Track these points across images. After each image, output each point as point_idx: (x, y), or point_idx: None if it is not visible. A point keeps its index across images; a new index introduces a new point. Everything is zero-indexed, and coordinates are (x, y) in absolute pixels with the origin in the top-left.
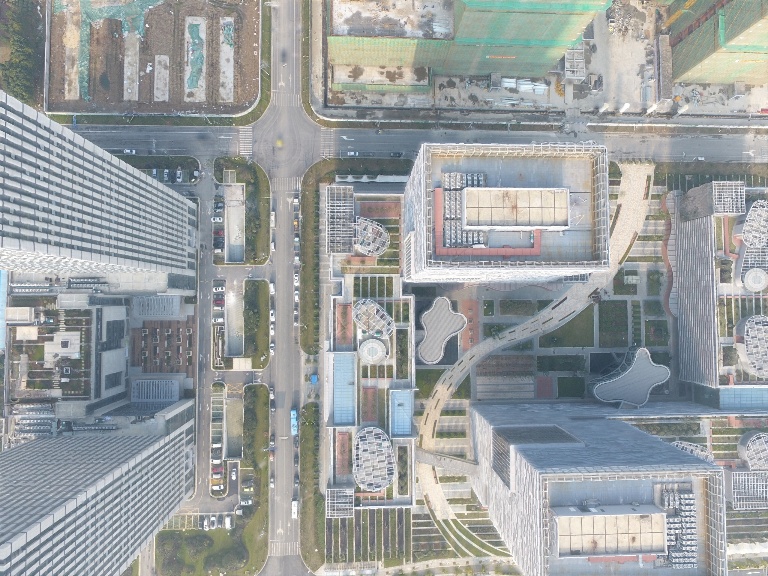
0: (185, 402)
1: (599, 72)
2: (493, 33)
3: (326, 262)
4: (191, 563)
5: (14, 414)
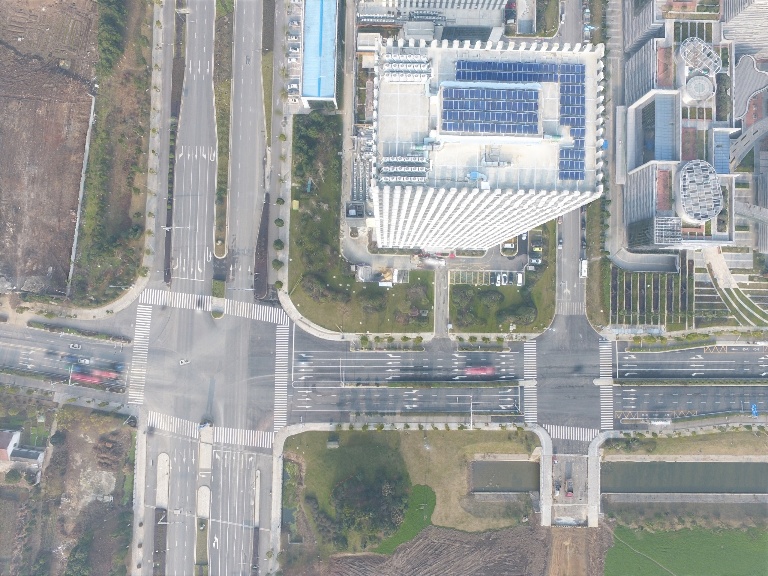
0: None
1: None
2: None
3: (613, 36)
4: (483, 316)
5: (361, 136)
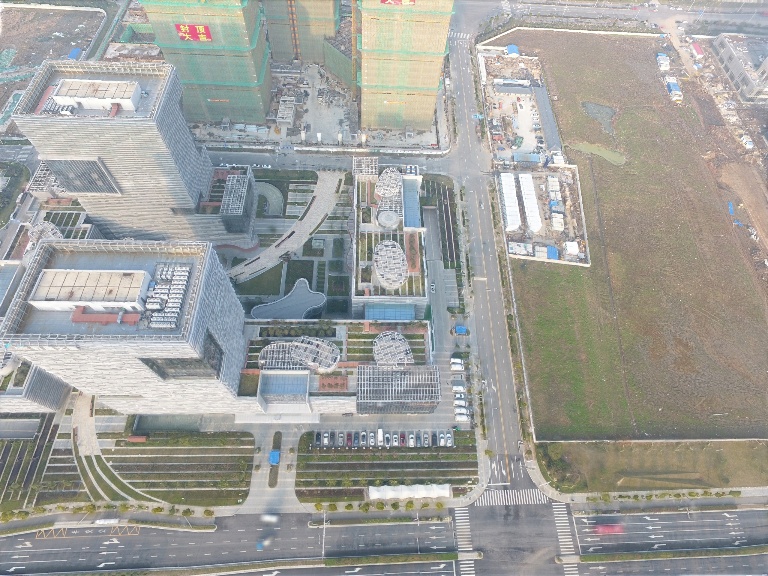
0: None
1: (309, 122)
2: (196, 75)
3: None
4: None
5: None
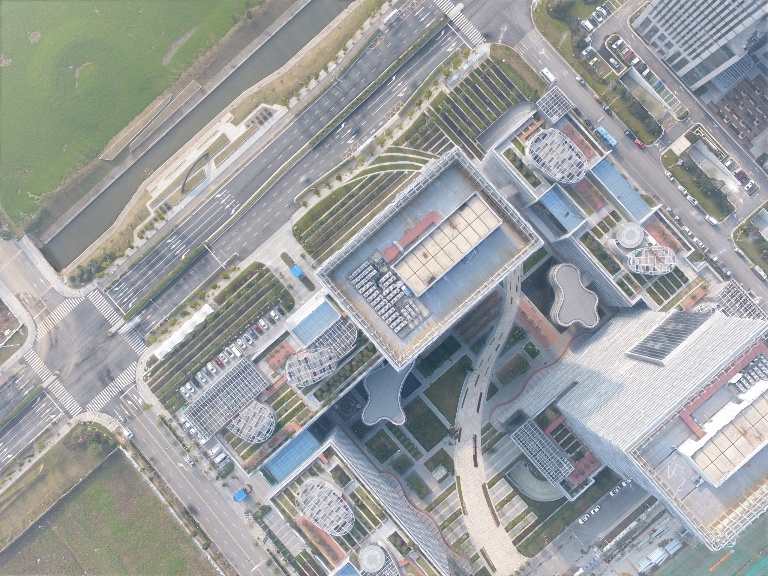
0: None
1: None
2: None
3: None
4: None
5: None
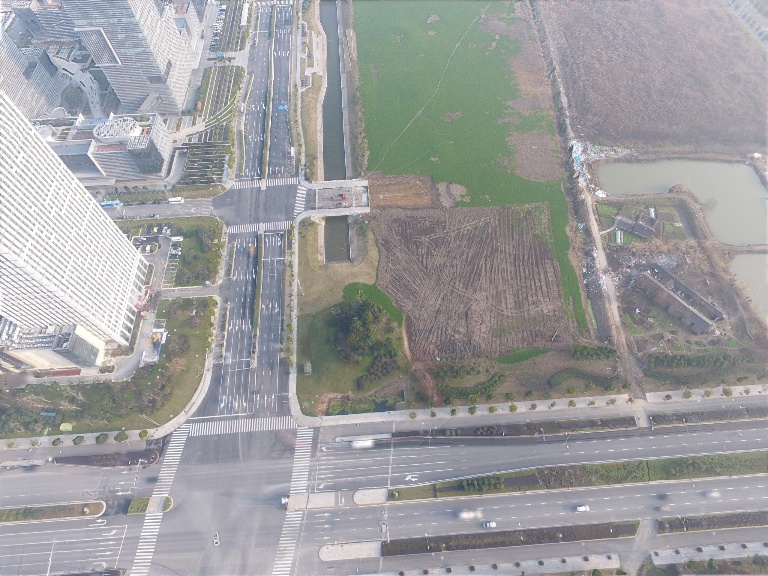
0: None
1: None
2: None
3: None
4: None
5: None
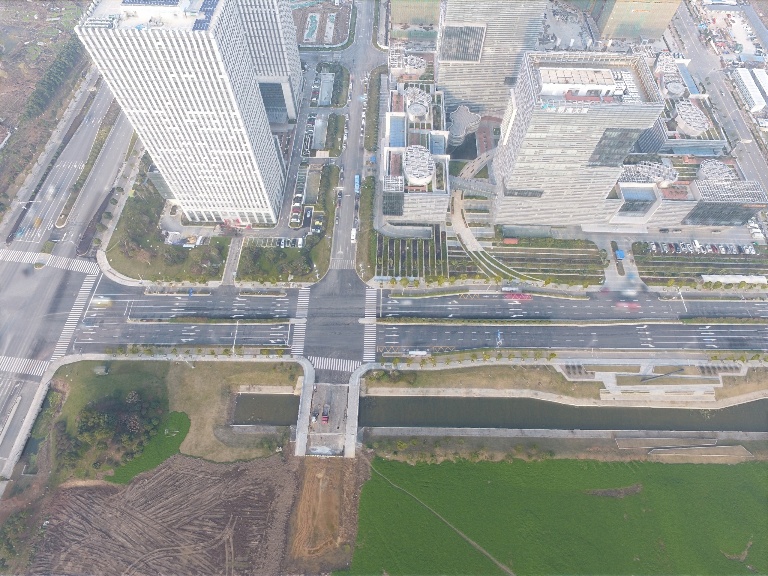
0: (283, 159)
1: None
2: None
3: (384, 107)
4: (266, 269)
5: None
